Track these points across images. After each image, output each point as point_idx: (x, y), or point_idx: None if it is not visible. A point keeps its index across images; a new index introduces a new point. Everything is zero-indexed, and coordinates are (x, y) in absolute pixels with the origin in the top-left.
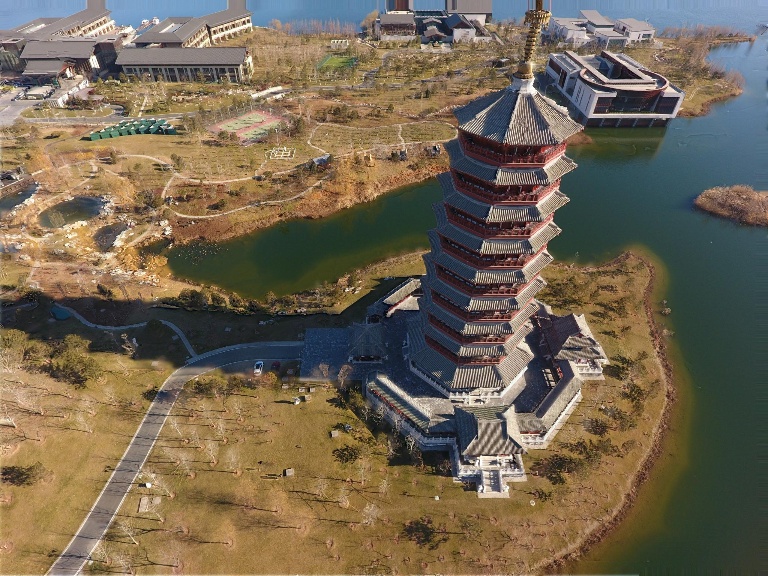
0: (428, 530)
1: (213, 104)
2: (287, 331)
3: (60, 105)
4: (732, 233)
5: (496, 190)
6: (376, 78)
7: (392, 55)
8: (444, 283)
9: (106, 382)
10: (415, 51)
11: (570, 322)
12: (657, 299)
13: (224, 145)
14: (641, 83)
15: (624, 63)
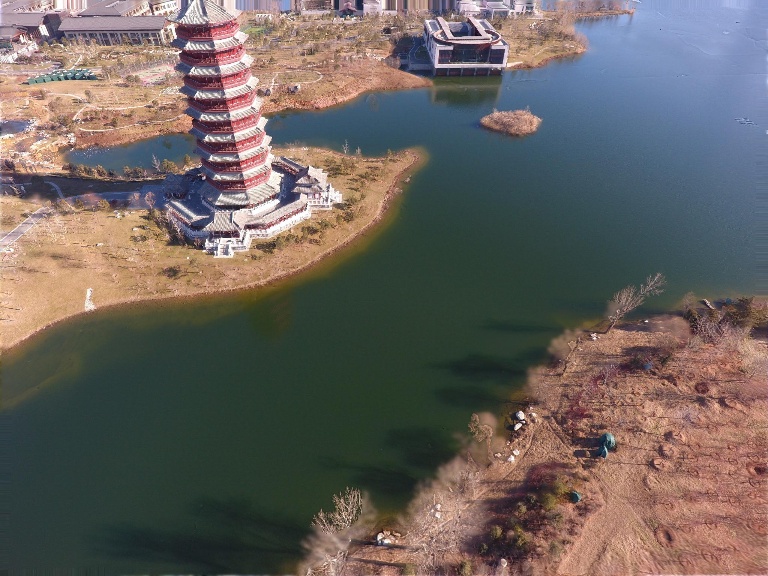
0: (176, 271)
1: (134, 60)
2: (130, 187)
3: (10, 61)
4: (504, 143)
5: (195, 57)
6: (280, 42)
7: (304, 26)
8: (197, 129)
9: None
10: (326, 23)
11: (307, 170)
12: (408, 175)
13: (130, 86)
14: (478, 39)
15: (477, 25)
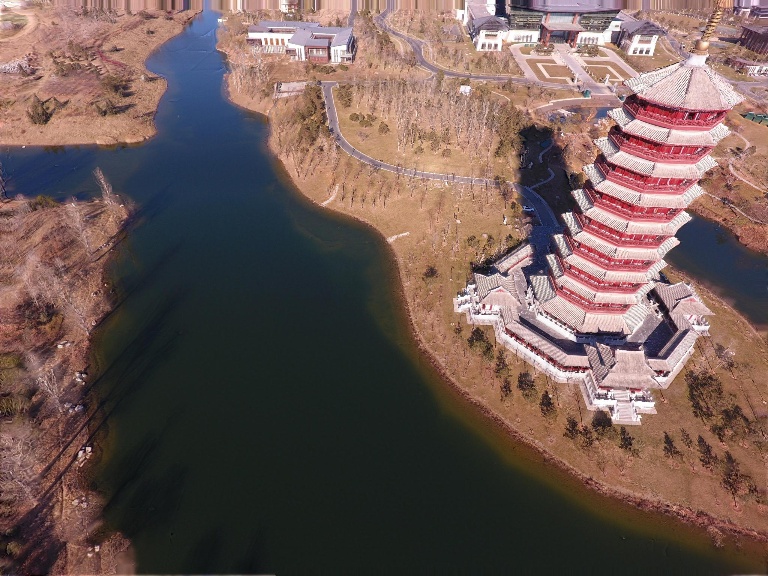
0: (432, 276)
1: None
2: None
3: None
4: None
5: None
6: None
7: None
8: None
9: (501, 162)
10: None
11: None
12: None
13: None
14: None
15: None
